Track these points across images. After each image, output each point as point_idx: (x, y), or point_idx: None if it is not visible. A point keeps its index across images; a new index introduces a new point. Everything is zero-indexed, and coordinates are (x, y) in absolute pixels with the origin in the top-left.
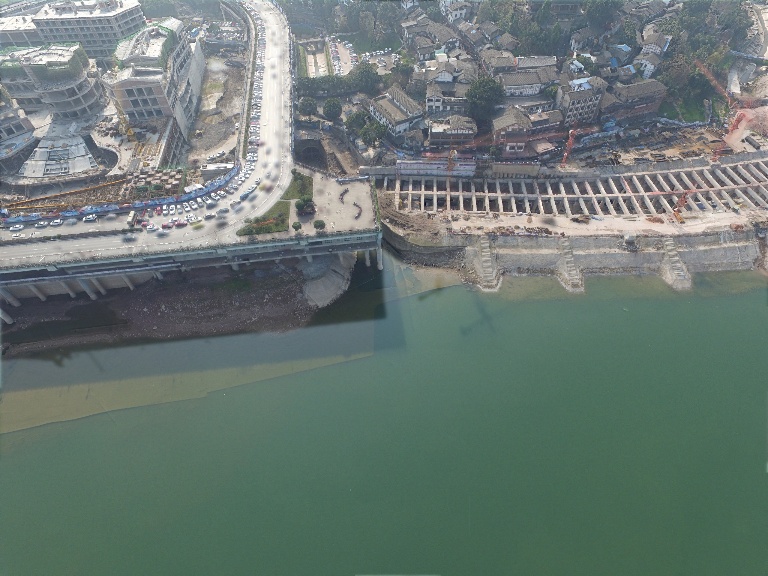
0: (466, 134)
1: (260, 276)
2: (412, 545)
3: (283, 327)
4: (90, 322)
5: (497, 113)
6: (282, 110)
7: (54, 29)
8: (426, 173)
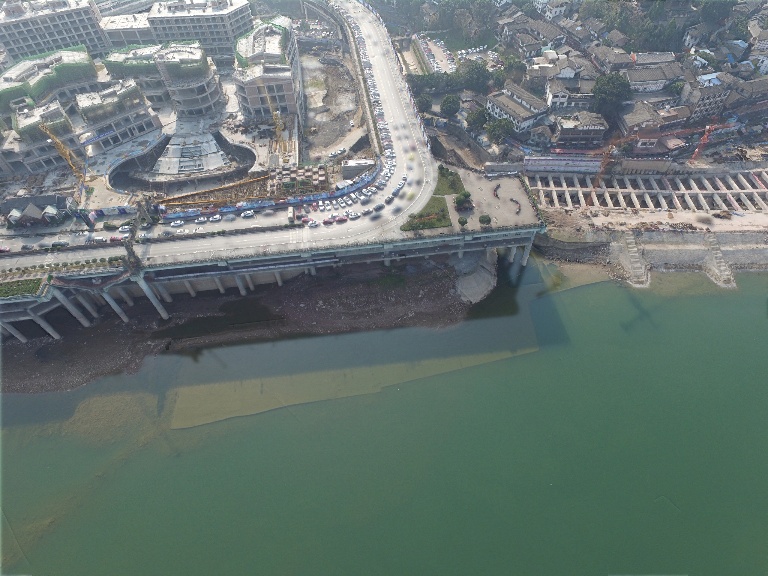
0: (597, 130)
1: (413, 272)
2: (657, 539)
3: (441, 322)
4: (246, 318)
5: (625, 109)
6: (404, 107)
7: (167, 27)
8: (553, 169)
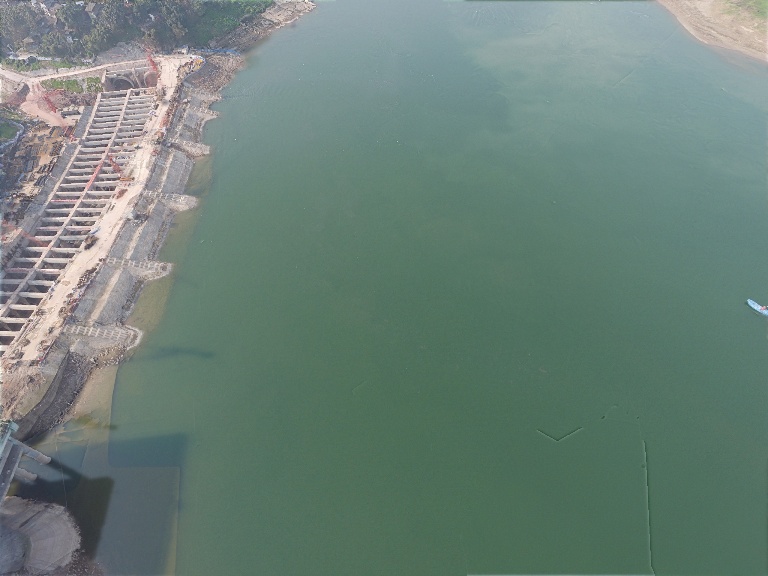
0: None
1: None
2: (385, 407)
3: None
4: None
5: None
6: None
7: None
8: None
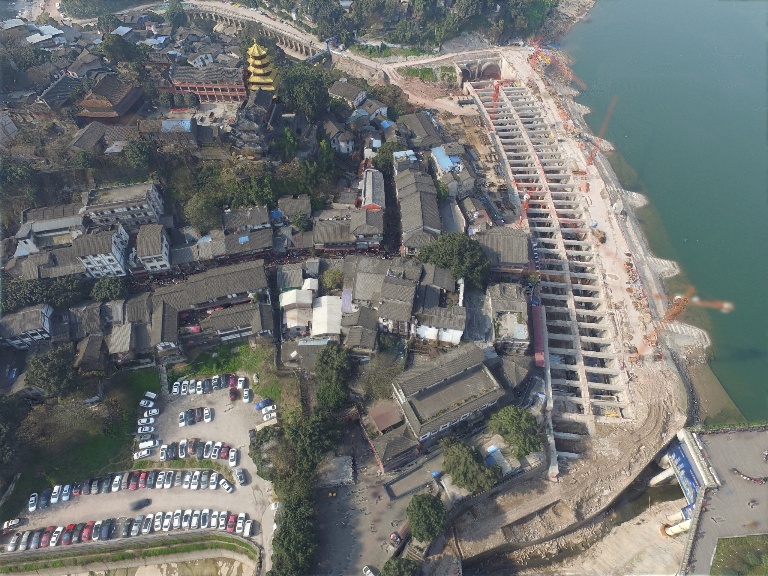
0: None
1: None
2: None
3: None
4: None
5: None
6: None
7: None
8: None
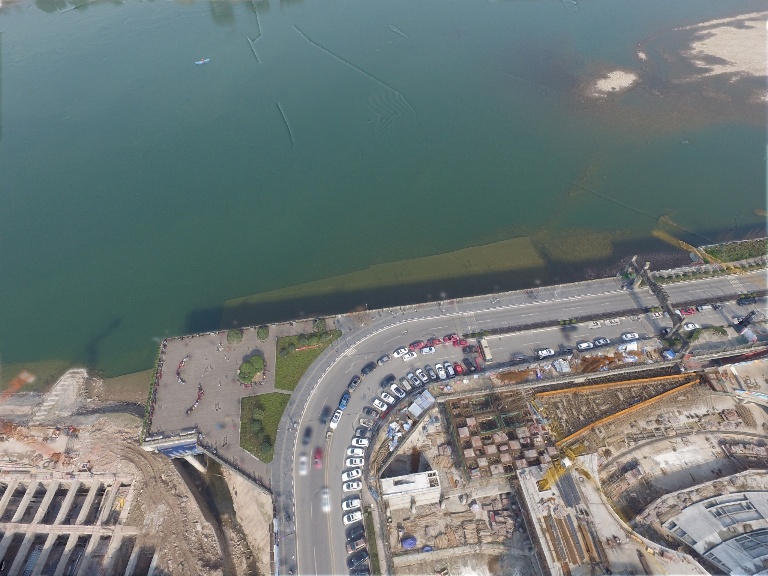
0: None
1: None
2: (216, 169)
3: None
4: None
5: None
6: None
7: None
8: None
